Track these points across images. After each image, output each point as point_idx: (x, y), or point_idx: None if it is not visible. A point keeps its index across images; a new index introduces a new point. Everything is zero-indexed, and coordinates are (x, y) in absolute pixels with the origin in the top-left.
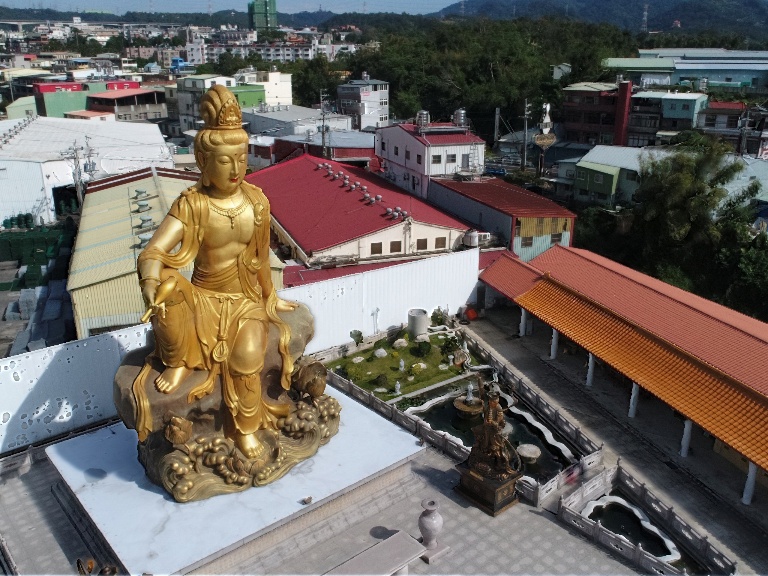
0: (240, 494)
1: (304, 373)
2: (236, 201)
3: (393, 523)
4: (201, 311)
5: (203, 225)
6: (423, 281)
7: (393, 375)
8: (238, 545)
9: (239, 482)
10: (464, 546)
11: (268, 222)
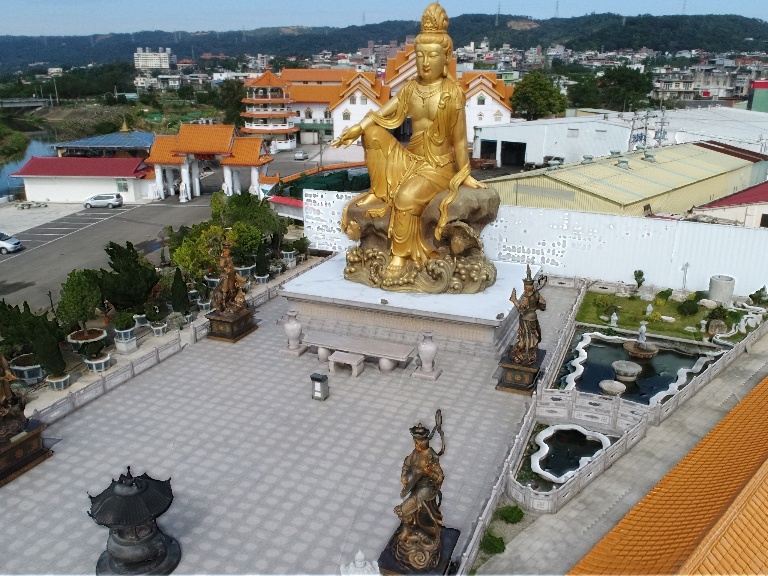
0: (371, 288)
1: (453, 232)
2: (433, 88)
3: (440, 357)
4: (394, 161)
5: (408, 102)
6: (764, 254)
7: None
8: (330, 300)
9: (374, 281)
10: (446, 385)
11: (455, 109)
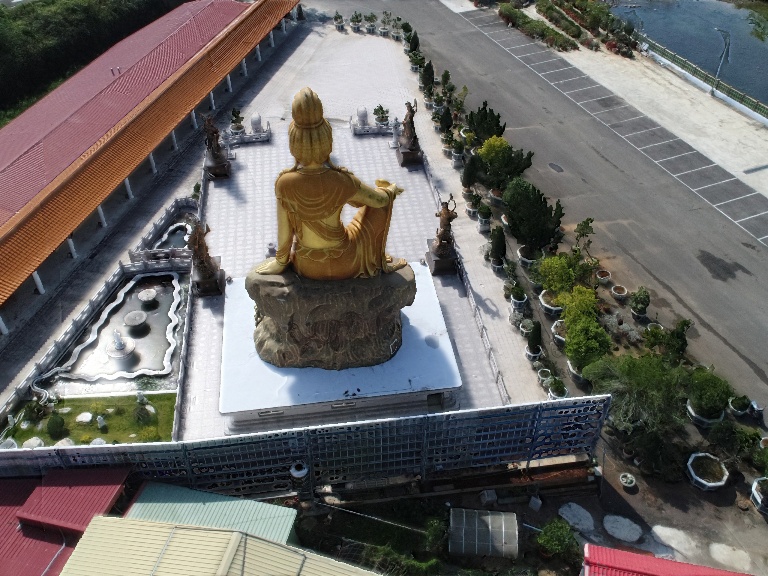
0: None
1: None
2: None
3: None
4: None
5: None
6: None
7: (117, 423)
8: None
9: None
10: None
11: None
